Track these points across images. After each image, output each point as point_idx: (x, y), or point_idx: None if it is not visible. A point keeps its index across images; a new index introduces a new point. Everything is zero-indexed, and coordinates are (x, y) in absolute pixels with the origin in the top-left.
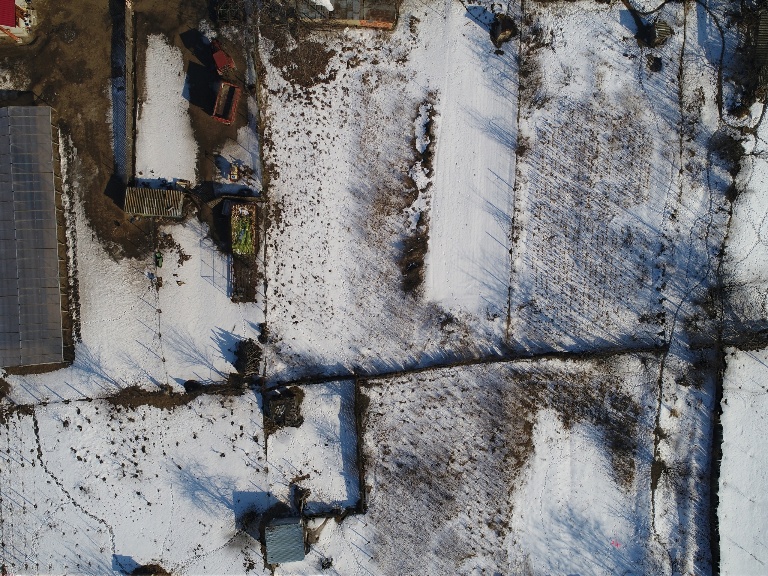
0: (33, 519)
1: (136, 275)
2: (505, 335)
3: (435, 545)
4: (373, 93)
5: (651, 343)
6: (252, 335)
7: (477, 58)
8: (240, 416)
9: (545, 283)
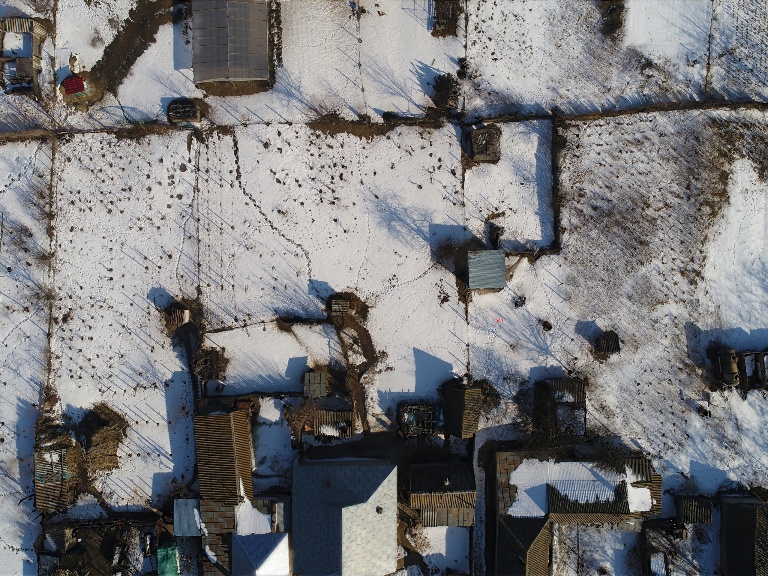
0: (230, 240)
1: (338, 3)
2: (704, 82)
3: (628, 290)
4: None
5: None
6: (451, 70)
7: None
8: (439, 148)
9: (745, 33)
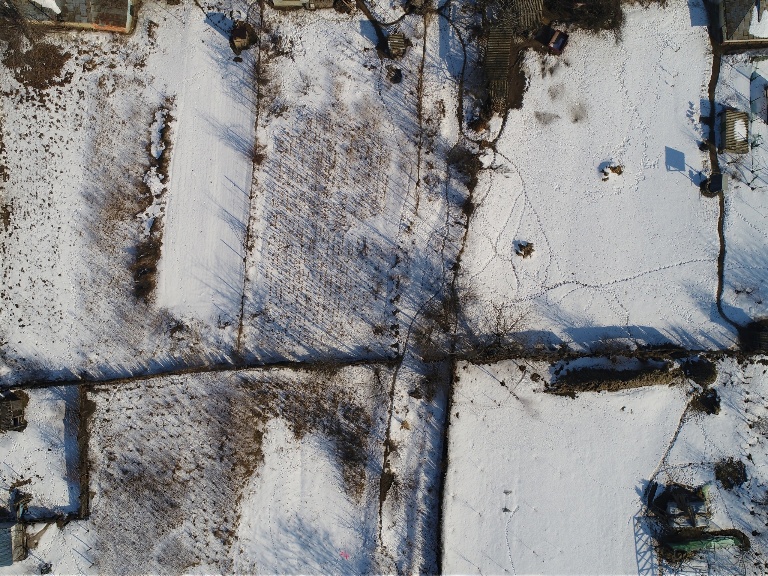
0: None
1: None
2: (236, 343)
3: (158, 553)
4: (109, 97)
5: (385, 355)
6: None
7: (216, 65)
8: None
9: (279, 292)
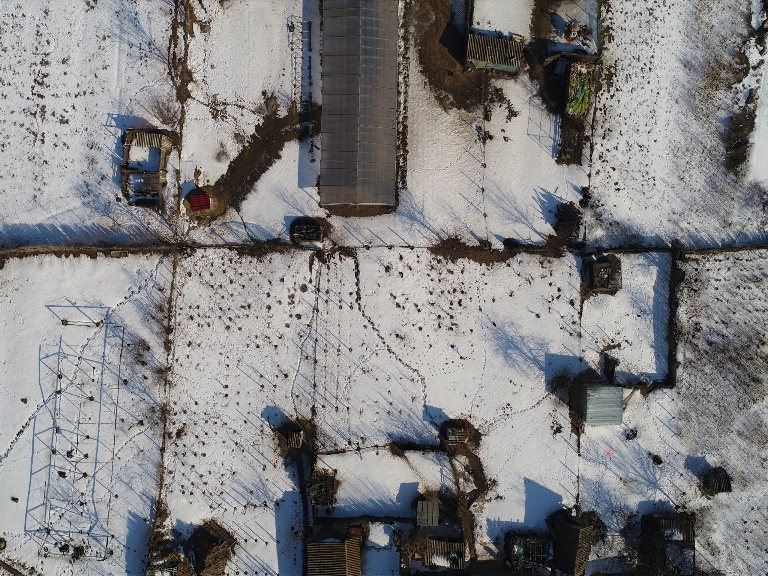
0: (347, 362)
1: (464, 127)
2: None
3: (739, 427)
4: None
5: None
6: (574, 198)
7: None
8: (558, 278)
9: None
